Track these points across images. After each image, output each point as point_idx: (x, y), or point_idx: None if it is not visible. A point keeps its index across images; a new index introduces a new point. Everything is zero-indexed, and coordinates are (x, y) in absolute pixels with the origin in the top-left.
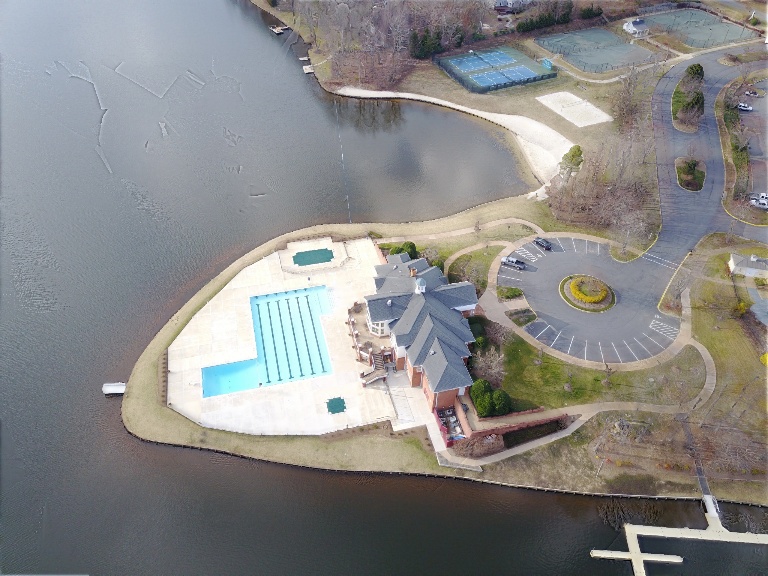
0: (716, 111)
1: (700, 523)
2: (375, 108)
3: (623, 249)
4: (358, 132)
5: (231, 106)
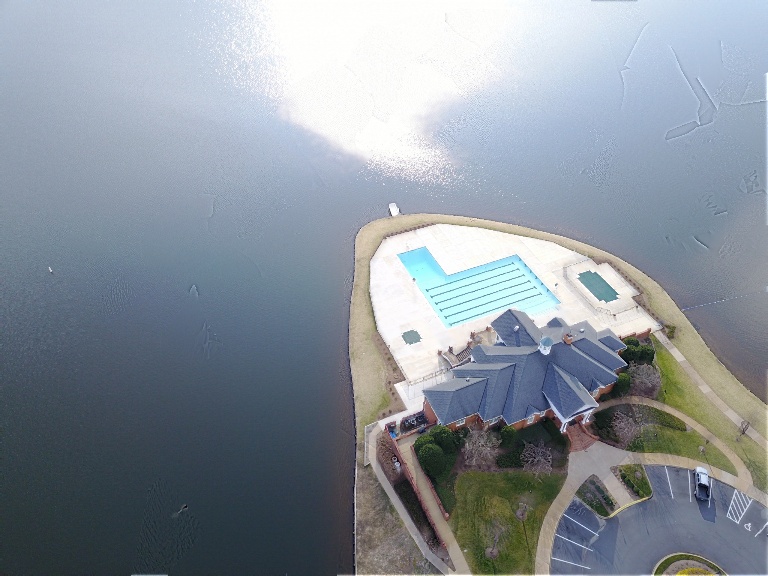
0: None
1: None
2: None
3: None
4: None
5: None
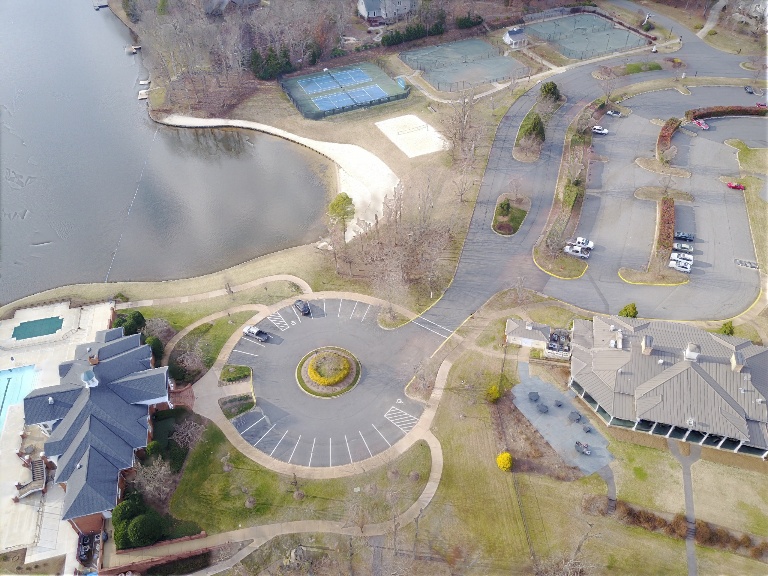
0: (567, 135)
1: None
2: (216, 135)
3: (390, 313)
4: None
5: (8, 146)
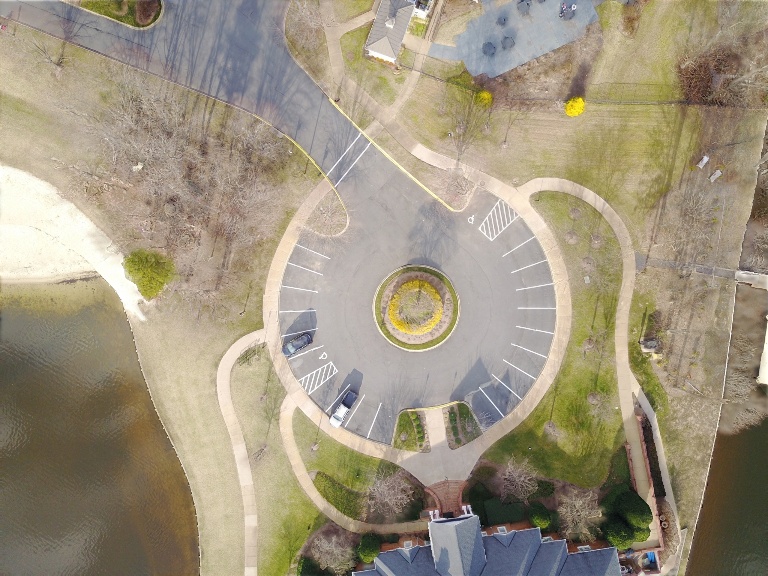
0: None
1: (759, 296)
2: None
3: None
4: None
5: None
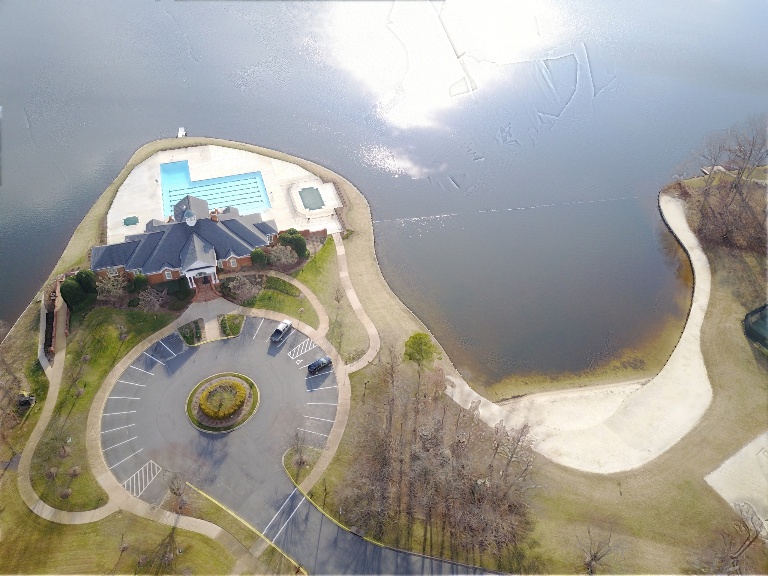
0: None
1: None
2: None
3: (300, 455)
4: (661, 261)
5: (516, 105)
